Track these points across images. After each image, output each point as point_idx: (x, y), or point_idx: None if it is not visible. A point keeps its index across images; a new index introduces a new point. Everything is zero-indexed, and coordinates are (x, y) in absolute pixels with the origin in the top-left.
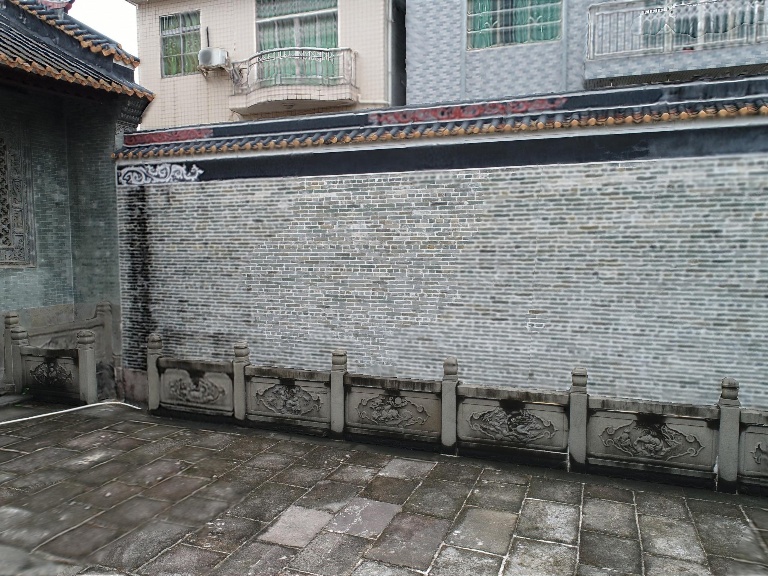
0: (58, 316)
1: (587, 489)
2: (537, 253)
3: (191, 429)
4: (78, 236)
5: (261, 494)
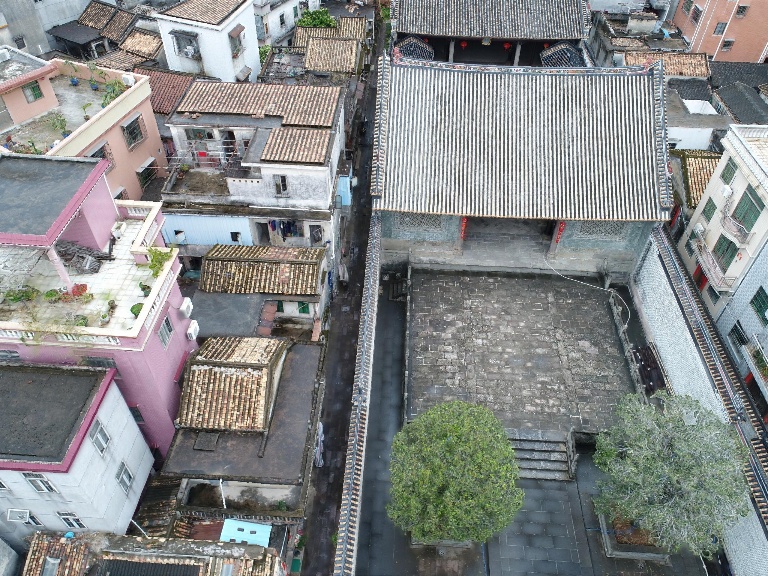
0: (627, 252)
1: None
2: None
3: (607, 313)
4: None
5: None
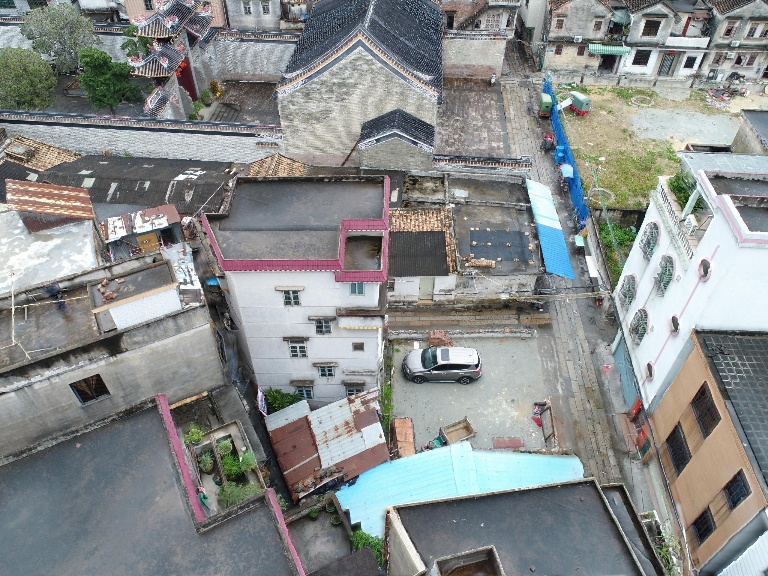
0: None
1: None
2: (3, 38)
3: None
4: None
5: None
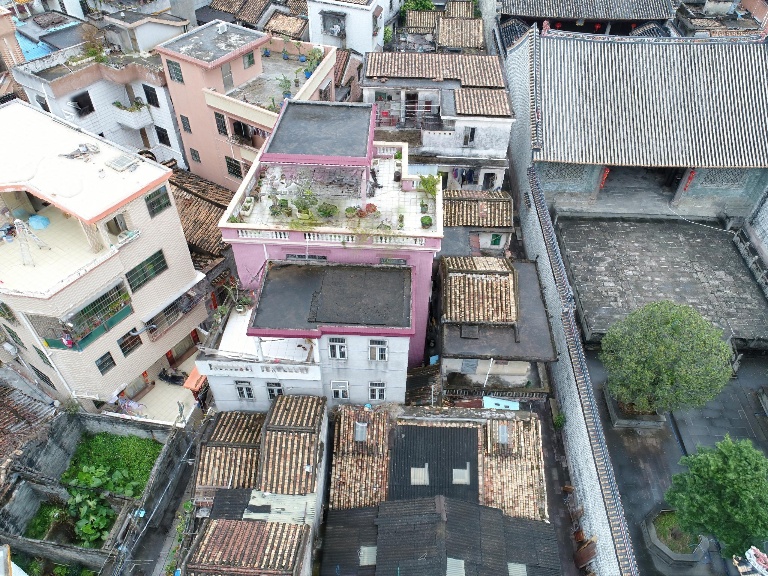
0: (742, 199)
1: (760, 299)
2: None
3: (733, 249)
4: (757, 185)
5: (723, 267)
